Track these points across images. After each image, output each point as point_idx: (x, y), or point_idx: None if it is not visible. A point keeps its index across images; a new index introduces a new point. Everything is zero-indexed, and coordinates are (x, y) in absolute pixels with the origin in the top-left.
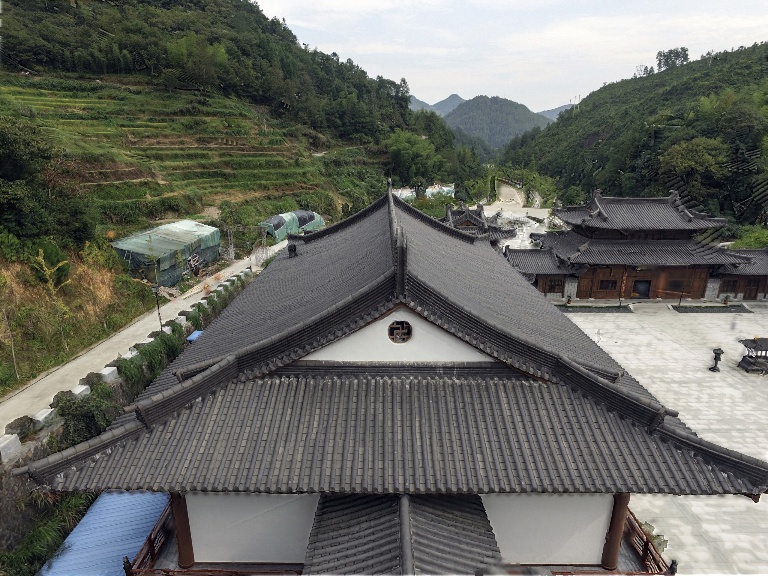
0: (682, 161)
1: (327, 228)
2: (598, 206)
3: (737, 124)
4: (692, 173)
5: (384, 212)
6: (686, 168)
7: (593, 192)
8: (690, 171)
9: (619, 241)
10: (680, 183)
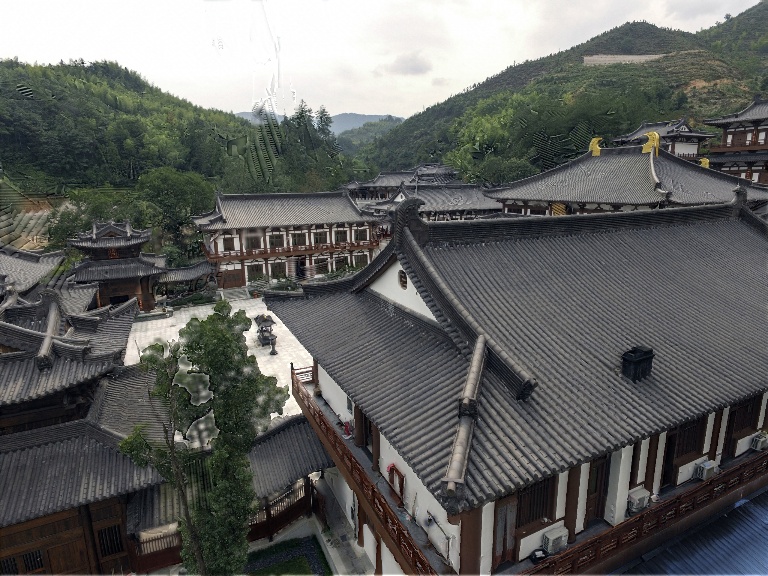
0: None
1: None
2: None
3: None
4: None
5: (491, 247)
6: None
7: None
8: None
9: None
10: (5, 216)
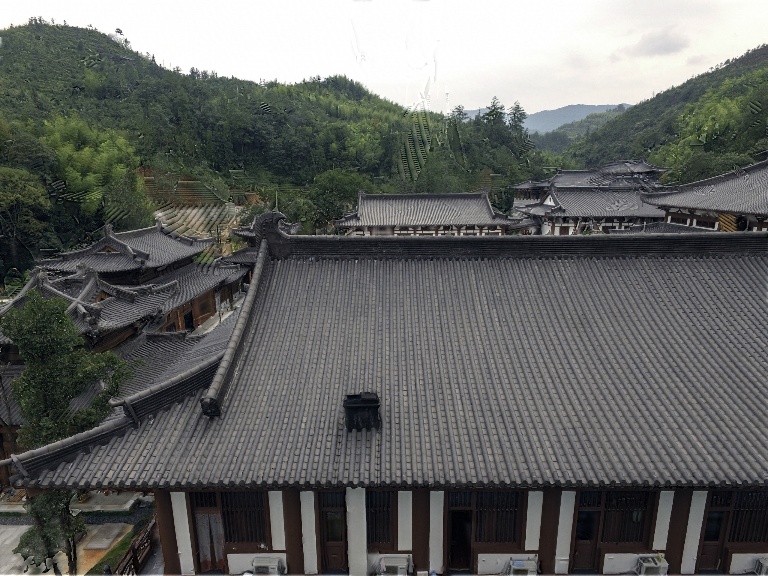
0: (4, 194)
1: (234, 350)
2: (124, 244)
3: (33, 154)
4: (16, 207)
5: (361, 265)
6: (13, 202)
7: (106, 229)
8: (14, 205)
9: (158, 279)
10: (171, 209)
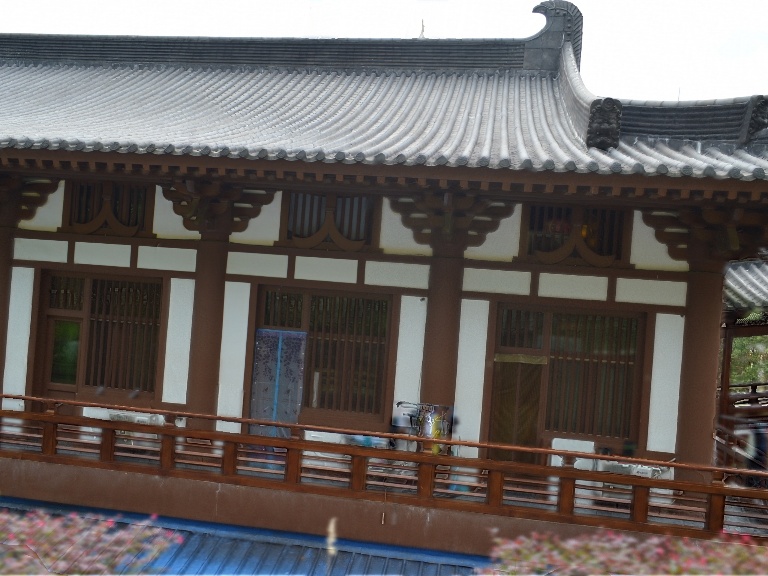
0: None
1: None
2: None
3: None
4: None
5: None
6: None
7: None
8: None
9: None
10: None
